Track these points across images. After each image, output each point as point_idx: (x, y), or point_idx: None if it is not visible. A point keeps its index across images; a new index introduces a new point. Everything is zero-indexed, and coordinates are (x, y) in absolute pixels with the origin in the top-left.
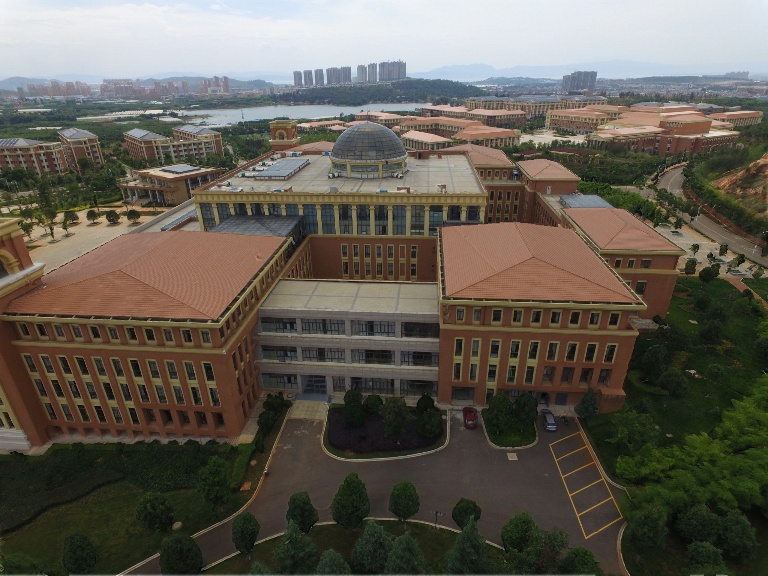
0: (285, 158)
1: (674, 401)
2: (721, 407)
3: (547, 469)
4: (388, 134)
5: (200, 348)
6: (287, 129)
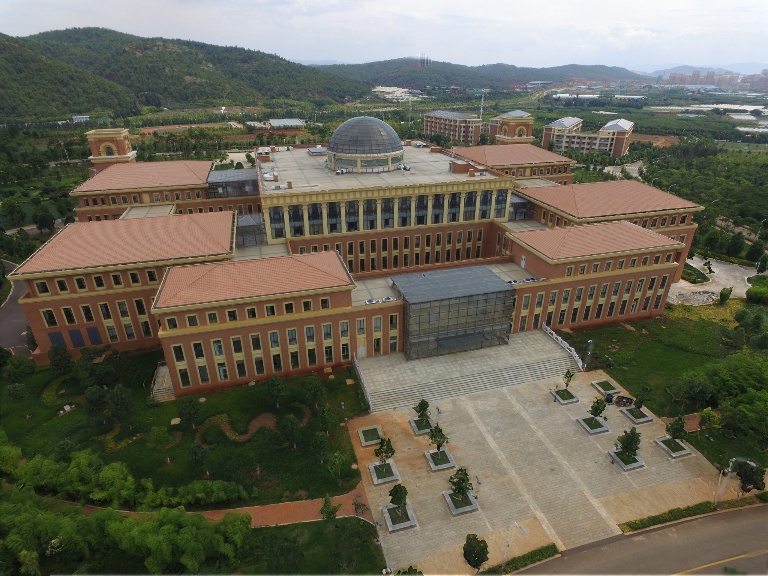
0: (405, 146)
1: (32, 395)
2: (5, 423)
3: (4, 345)
4: (355, 129)
5: None
6: (509, 125)
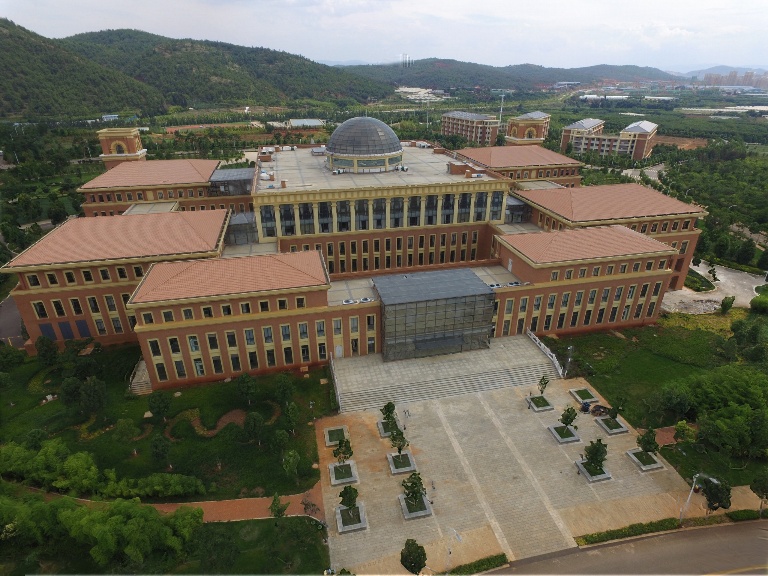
0: (410, 147)
1: (19, 384)
2: None
3: (3, 335)
4: (353, 130)
5: (87, 201)
6: (518, 126)
